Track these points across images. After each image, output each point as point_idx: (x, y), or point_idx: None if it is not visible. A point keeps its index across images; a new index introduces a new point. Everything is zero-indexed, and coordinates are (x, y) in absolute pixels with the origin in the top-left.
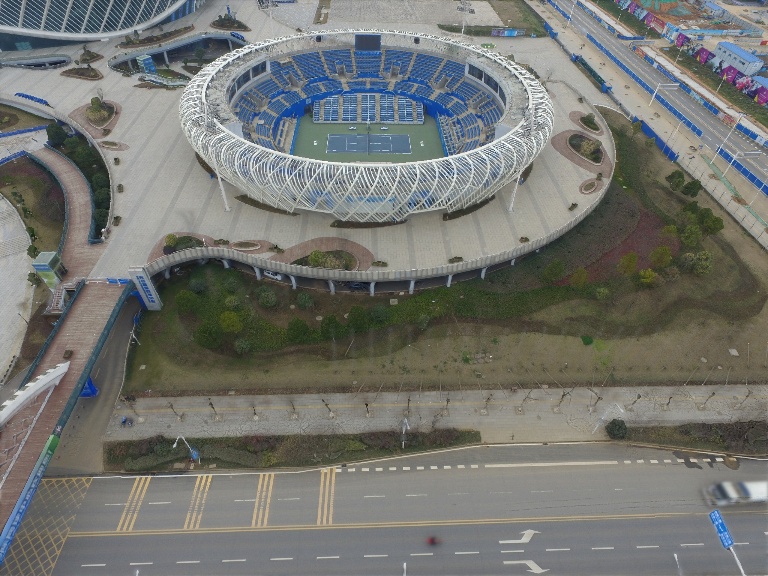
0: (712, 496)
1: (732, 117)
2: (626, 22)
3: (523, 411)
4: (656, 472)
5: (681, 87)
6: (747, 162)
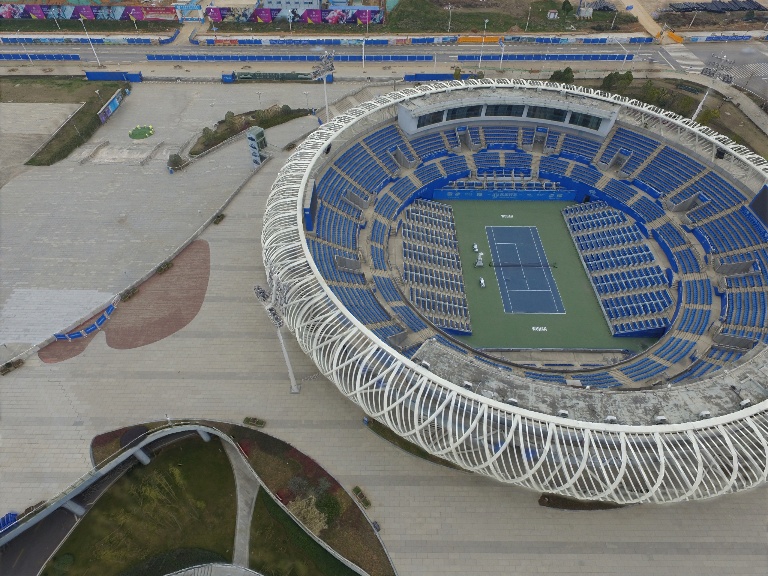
0: None
1: None
2: (110, 29)
3: None
4: None
5: (324, 44)
6: (470, 54)
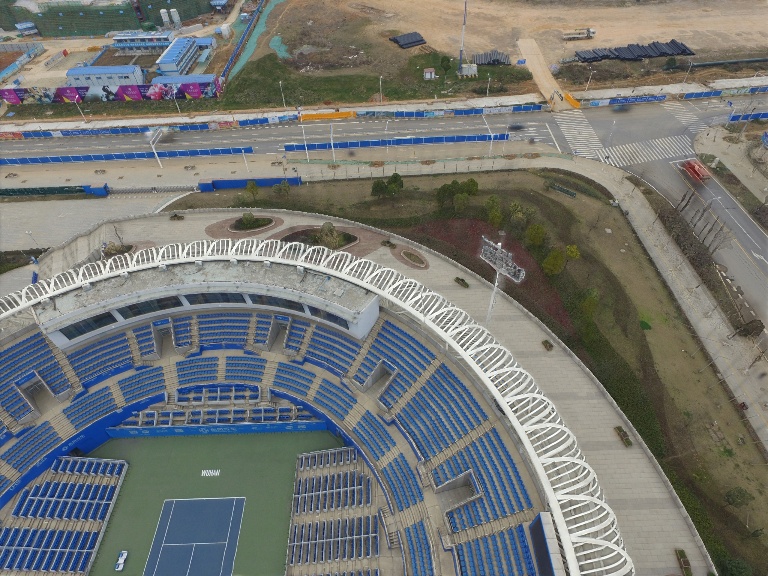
0: (762, 288)
1: (214, 121)
2: None
3: (764, 403)
4: (763, 315)
5: (129, 132)
6: (307, 140)
